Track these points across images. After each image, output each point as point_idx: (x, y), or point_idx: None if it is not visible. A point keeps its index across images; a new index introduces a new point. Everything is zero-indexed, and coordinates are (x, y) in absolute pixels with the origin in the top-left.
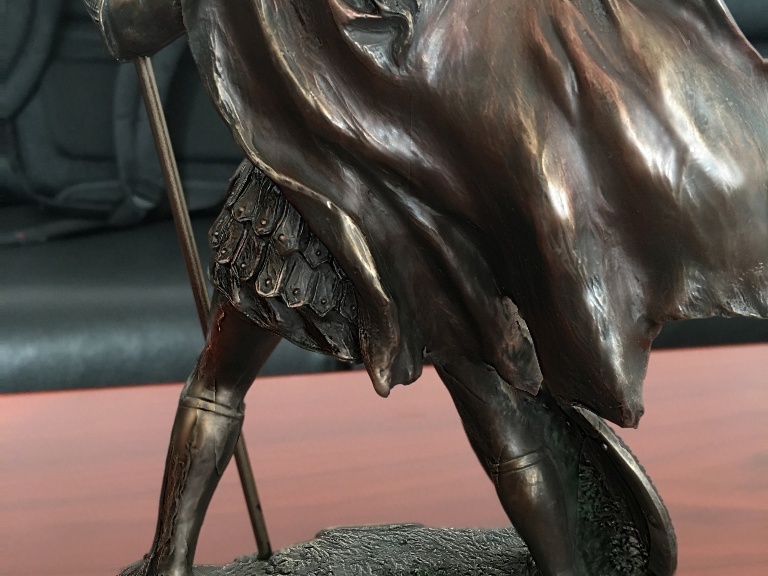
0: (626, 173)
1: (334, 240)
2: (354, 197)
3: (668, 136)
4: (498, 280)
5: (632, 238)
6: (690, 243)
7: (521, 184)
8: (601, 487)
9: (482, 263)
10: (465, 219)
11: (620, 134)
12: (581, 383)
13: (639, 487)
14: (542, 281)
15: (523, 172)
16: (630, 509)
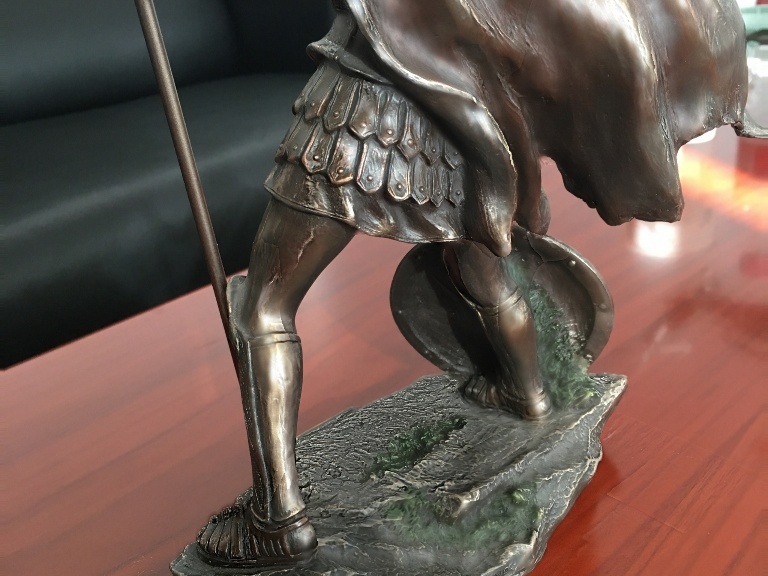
0: (684, 34)
1: (481, 130)
2: (478, 91)
3: (706, 3)
4: (540, 144)
5: (676, 83)
6: (711, 79)
7: (624, 54)
8: (547, 302)
9: (532, 133)
10: (543, 95)
11: (682, 6)
12: (647, 199)
13: (598, 285)
14: (626, 128)
15: (626, 44)
16: (573, 309)
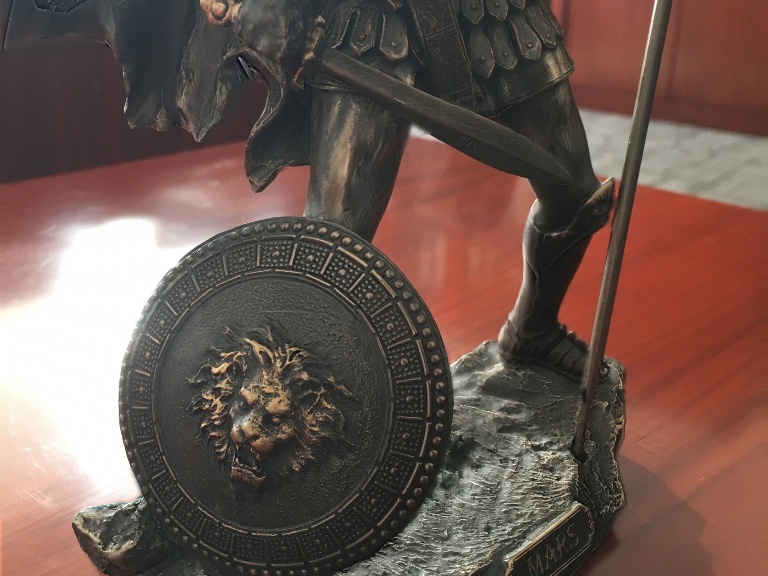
0: None
1: None
2: None
3: None
4: None
5: None
6: None
7: None
8: None
9: None
10: None
11: None
12: None
13: None
14: None
15: None
16: None
